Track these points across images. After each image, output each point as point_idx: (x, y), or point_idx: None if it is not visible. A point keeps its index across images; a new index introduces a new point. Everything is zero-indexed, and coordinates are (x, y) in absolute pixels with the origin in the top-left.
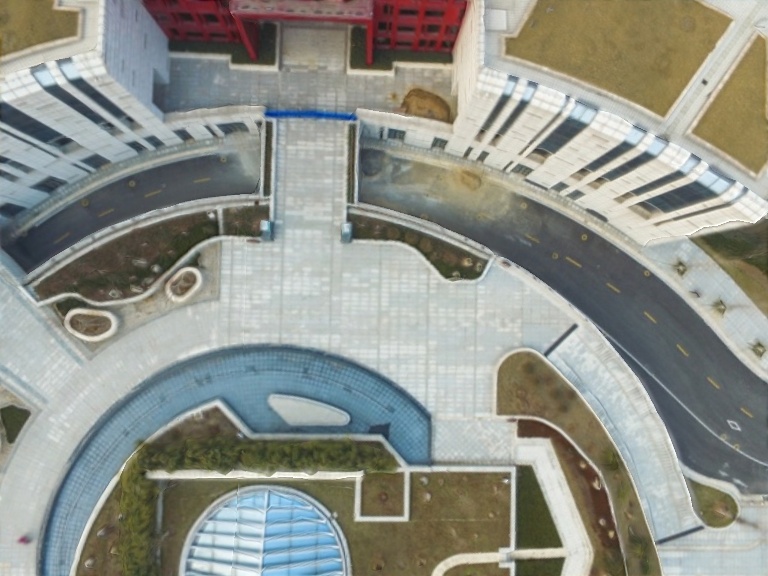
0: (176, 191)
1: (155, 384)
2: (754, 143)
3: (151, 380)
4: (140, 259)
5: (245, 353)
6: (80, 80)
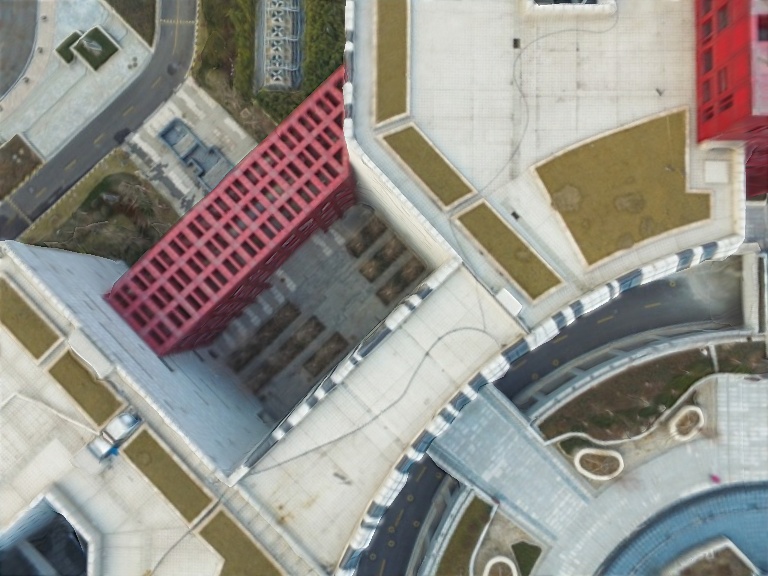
0: (627, 316)
1: (660, 522)
2: None
3: (656, 518)
4: (640, 398)
5: (747, 491)
6: (706, 259)
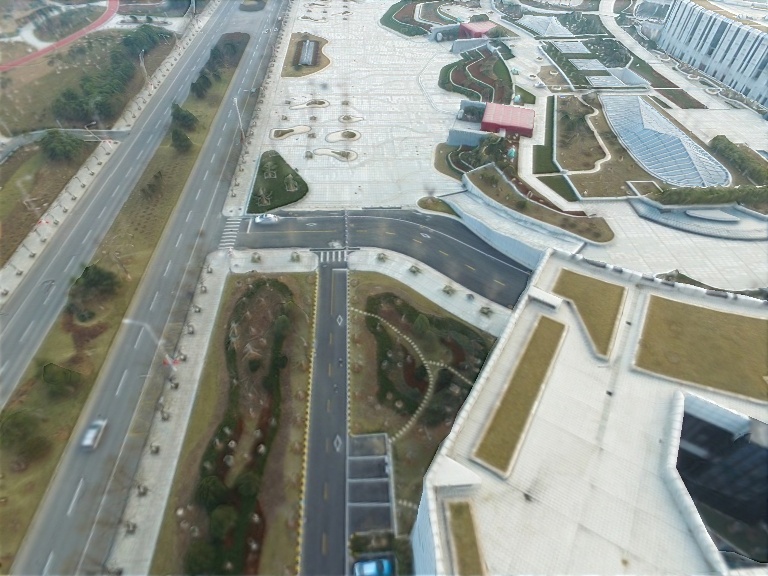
0: None
1: None
2: (574, 284)
3: None
4: None
5: None
6: None
